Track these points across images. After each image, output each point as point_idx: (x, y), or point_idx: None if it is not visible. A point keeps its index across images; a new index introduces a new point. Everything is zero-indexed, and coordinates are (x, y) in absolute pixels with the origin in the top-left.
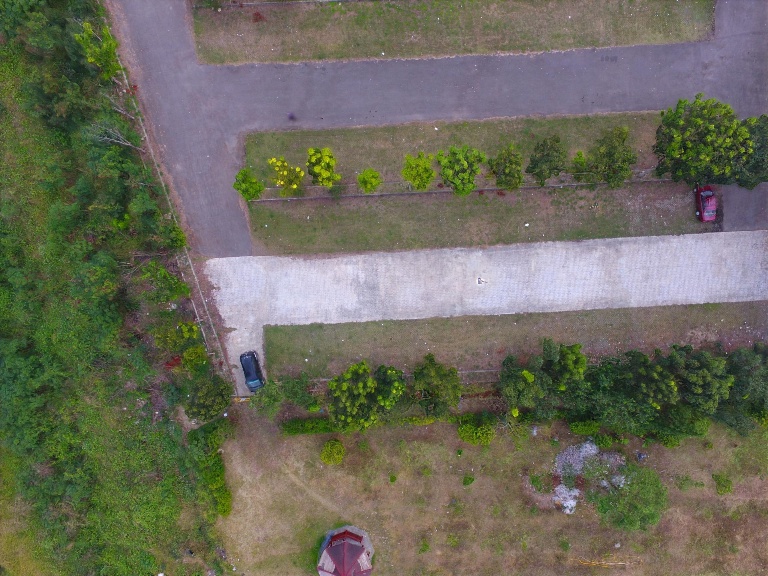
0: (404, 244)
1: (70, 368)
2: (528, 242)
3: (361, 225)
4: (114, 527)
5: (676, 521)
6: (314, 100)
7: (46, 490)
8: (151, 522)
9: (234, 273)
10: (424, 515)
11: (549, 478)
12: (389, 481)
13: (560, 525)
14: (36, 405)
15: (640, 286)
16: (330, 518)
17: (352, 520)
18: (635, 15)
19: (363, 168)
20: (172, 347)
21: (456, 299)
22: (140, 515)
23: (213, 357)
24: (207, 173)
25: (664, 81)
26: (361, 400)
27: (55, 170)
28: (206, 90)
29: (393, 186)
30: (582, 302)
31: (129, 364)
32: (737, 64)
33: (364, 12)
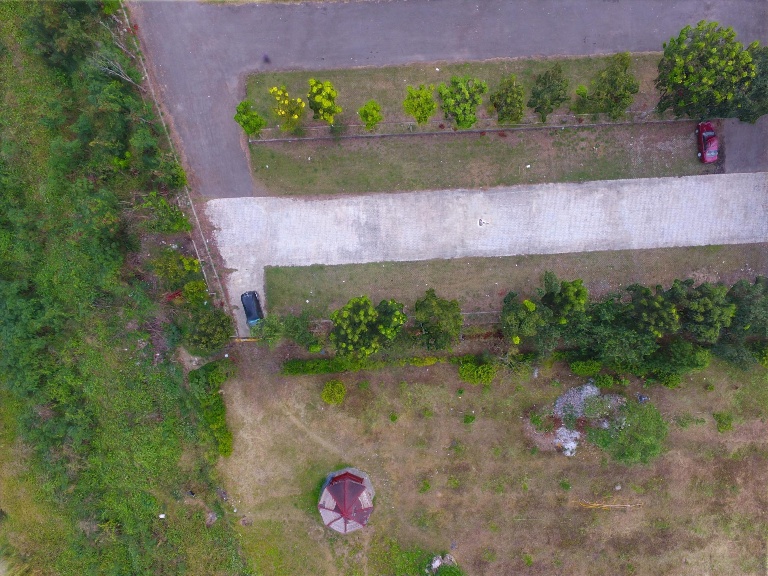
0: (405, 185)
1: (71, 309)
2: (529, 183)
3: (362, 166)
4: (115, 470)
5: (677, 463)
6: (315, 40)
7: (47, 433)
8: (152, 463)
9: (235, 214)
10: (425, 457)
11: (550, 420)
12: (390, 423)
13: (561, 467)
14: (37, 346)
15: (641, 228)
16: (331, 460)
17: (353, 462)
18: None
19: None
20: (173, 278)
21: (457, 240)
22: (141, 455)
23: (214, 298)
24: (208, 113)
25: (666, 22)
26: (362, 327)
27: (56, 107)
28: (207, 30)
29: (394, 127)
30: (583, 244)
31: (130, 304)
32: (739, 5)
33: None
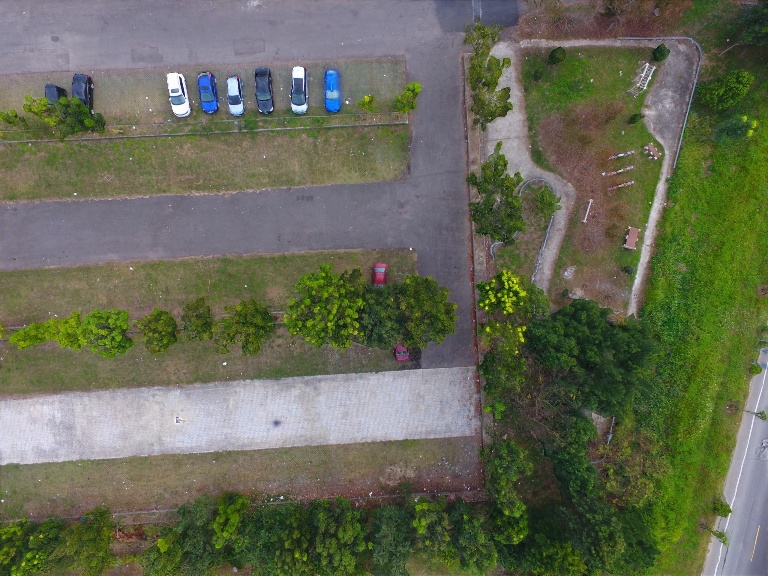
0: (101, 384)
1: None
2: (226, 381)
3: (56, 365)
4: None
5: None
6: (6, 241)
7: None
8: None
9: None
10: None
11: None
12: None
13: None
14: None
15: (339, 423)
16: None
17: None
18: (330, 154)
19: (57, 308)
20: None
21: (154, 438)
22: None
23: None
24: None
25: (360, 220)
26: None
27: None
28: None
29: None
30: (281, 440)
31: None
32: (433, 203)
33: (54, 153)
